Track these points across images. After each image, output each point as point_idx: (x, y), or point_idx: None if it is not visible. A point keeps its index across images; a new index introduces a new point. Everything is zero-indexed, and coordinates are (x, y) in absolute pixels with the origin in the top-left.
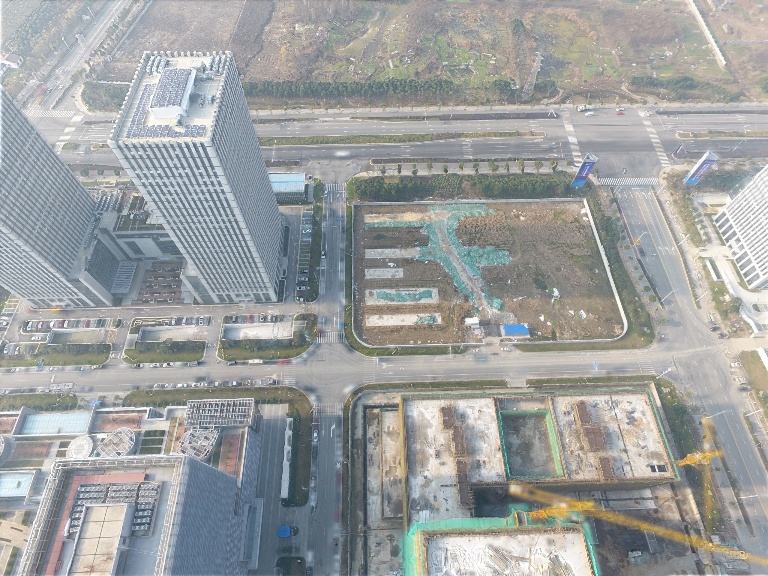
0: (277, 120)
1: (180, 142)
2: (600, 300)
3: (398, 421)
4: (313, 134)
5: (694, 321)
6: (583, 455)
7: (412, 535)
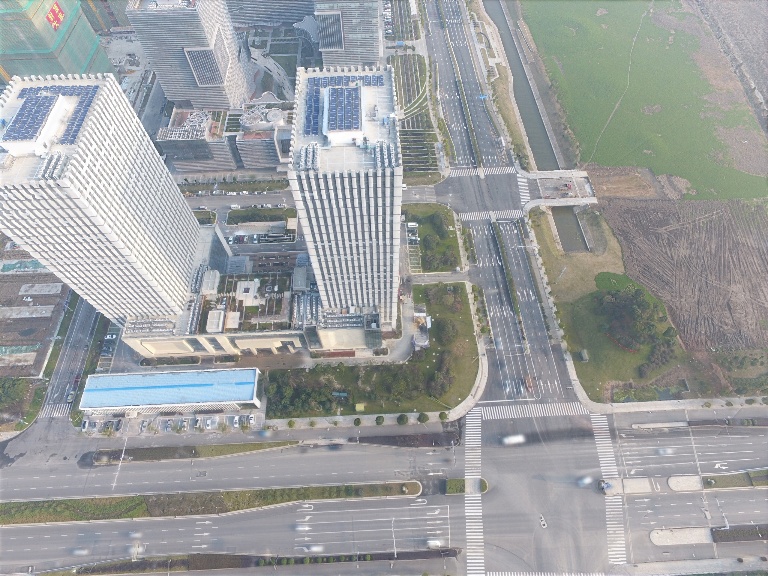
0: (110, 567)
1: (47, 84)
2: None
3: None
4: (55, 530)
5: None
6: None
7: (26, 8)
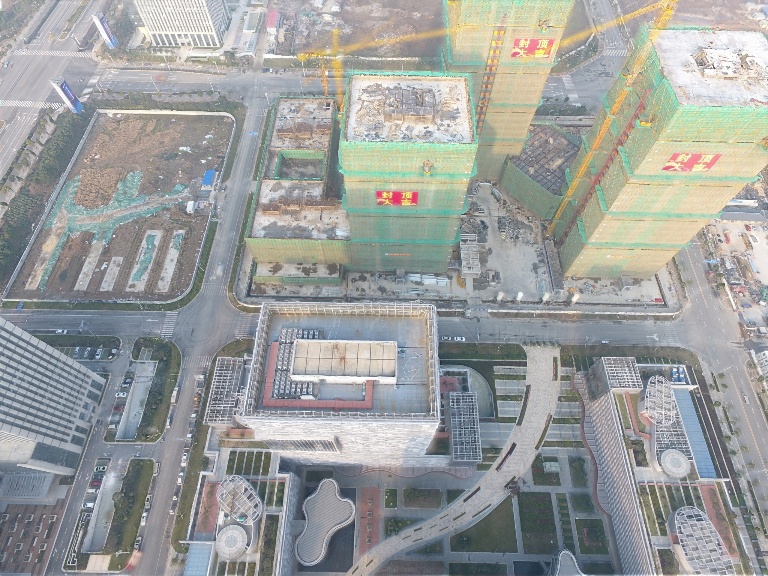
0: None
1: None
2: (200, 124)
3: (266, 263)
4: None
5: (234, 80)
6: (313, 139)
7: (345, 173)
